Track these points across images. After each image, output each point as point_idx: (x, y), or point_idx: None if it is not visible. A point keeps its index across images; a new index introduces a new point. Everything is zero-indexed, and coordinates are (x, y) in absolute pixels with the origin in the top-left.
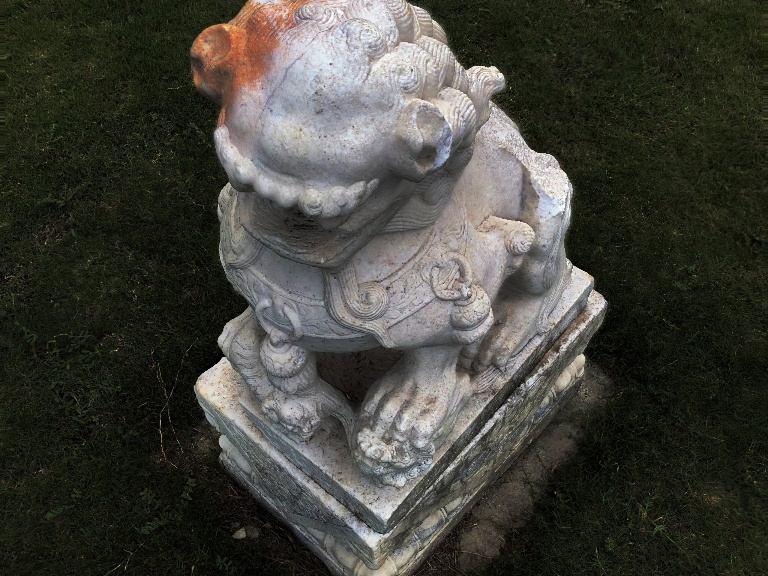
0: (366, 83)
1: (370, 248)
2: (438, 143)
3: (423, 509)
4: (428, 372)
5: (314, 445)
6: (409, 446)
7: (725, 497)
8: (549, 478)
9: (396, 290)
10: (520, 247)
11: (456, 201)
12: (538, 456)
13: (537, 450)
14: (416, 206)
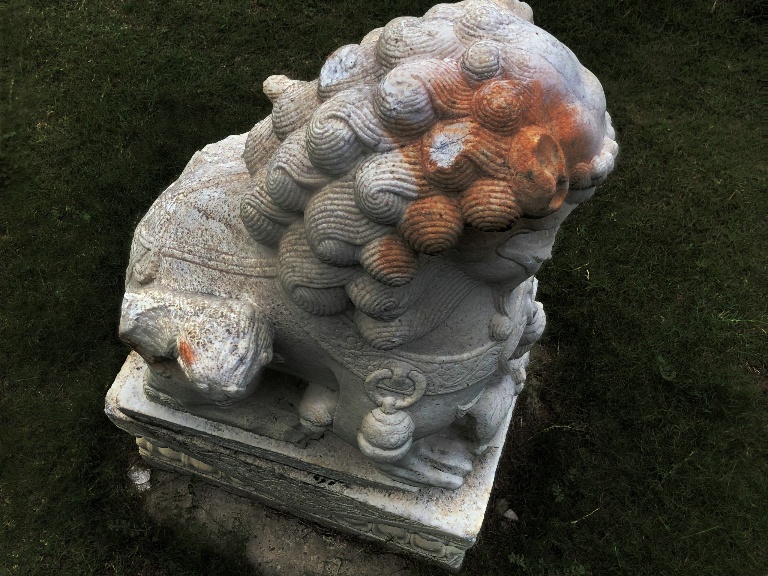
0: None
1: None
2: None
3: None
4: None
5: None
6: None
7: None
8: None
9: None
10: None
11: None
12: None
13: None
14: None
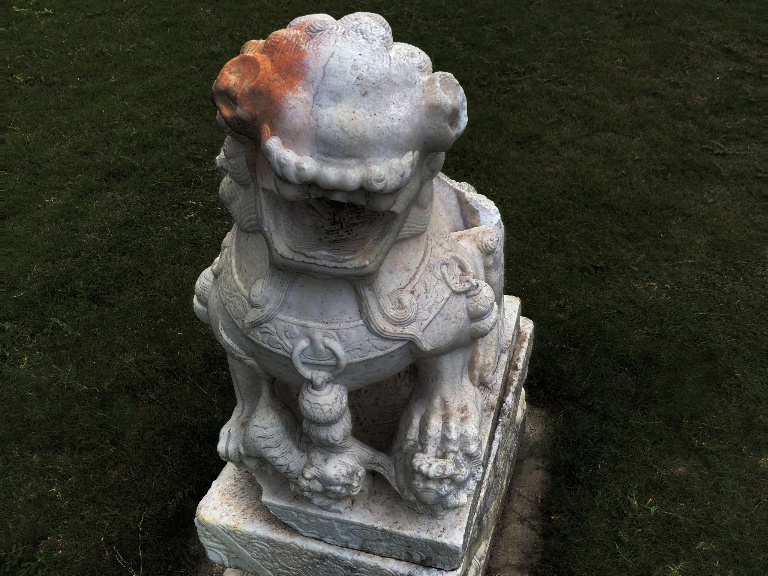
0: (391, 66)
1: (386, 259)
2: (459, 107)
3: (473, 543)
4: (451, 383)
5: (358, 508)
6: (462, 456)
7: (688, 465)
8: (540, 508)
9: (419, 292)
10: (491, 244)
11: (433, 211)
12: (520, 494)
13: (516, 490)
14: (414, 211)
